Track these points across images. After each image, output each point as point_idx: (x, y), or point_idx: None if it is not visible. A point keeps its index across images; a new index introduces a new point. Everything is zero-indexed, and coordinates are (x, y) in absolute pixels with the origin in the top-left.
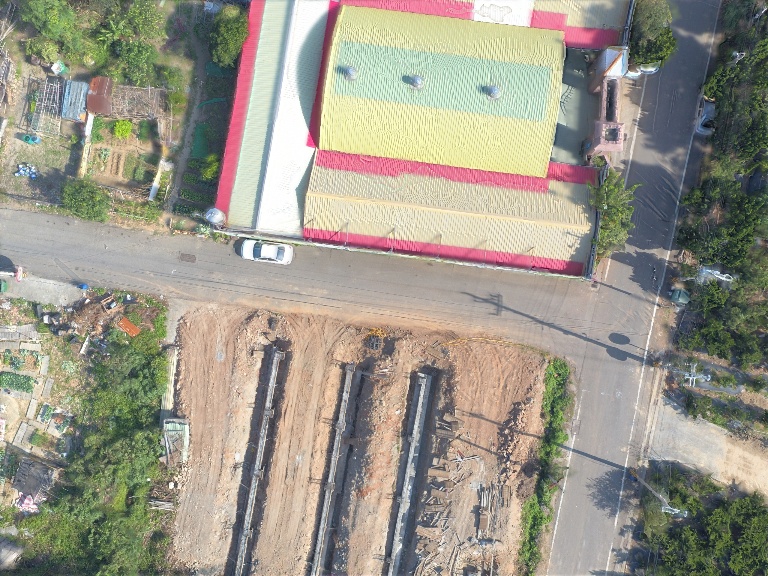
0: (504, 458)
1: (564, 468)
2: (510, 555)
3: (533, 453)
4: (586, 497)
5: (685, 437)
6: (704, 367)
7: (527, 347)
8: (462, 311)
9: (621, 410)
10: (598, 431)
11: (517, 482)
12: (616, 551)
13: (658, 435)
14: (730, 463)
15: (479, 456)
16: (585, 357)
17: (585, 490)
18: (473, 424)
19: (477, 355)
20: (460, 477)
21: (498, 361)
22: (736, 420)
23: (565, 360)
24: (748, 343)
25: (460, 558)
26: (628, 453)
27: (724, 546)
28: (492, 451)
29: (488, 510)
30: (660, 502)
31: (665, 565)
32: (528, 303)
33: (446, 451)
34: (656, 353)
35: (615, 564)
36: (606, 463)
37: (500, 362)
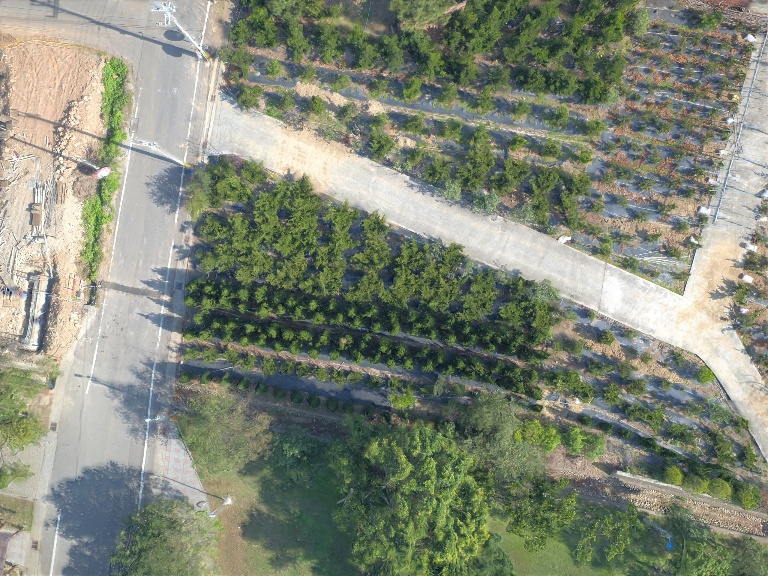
0: (57, 154)
1: (110, 157)
2: (69, 254)
3: (93, 153)
4: (146, 194)
5: (241, 130)
6: (260, 61)
7: (84, 48)
8: (19, 14)
9: (178, 106)
10: (155, 128)
11: (72, 179)
12: (178, 248)
13: (216, 130)
14: (285, 154)
15: (35, 155)
16: (142, 56)
17: (145, 188)
18: (29, 124)
19: (33, 57)
20: (16, 176)
21: (54, 62)
22: (292, 112)
23: (123, 60)
24: (289, 27)
25: (20, 259)
26: (187, 149)
27: (275, 232)
28: (47, 149)
29: (41, 206)
30: (201, 184)
31: (215, 252)
32: (84, 4)
33: (2, 151)
34: (212, 49)
35: (177, 261)
36: (164, 160)
37: (56, 63)
